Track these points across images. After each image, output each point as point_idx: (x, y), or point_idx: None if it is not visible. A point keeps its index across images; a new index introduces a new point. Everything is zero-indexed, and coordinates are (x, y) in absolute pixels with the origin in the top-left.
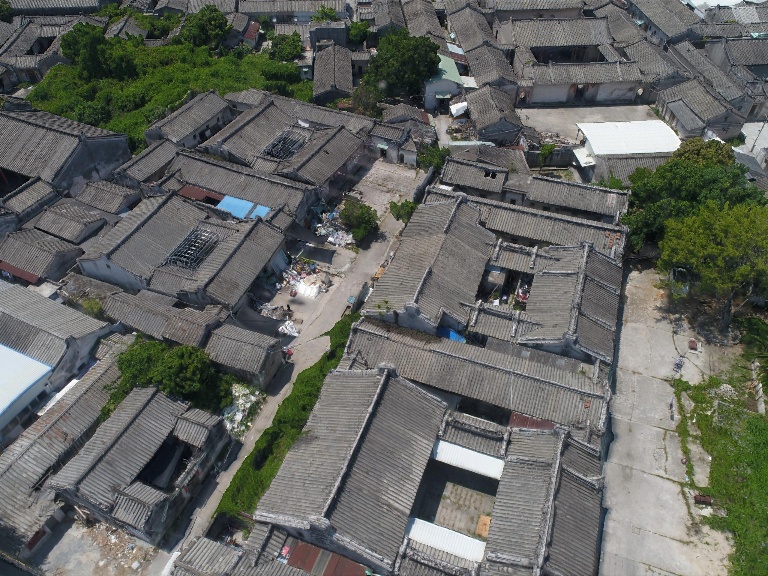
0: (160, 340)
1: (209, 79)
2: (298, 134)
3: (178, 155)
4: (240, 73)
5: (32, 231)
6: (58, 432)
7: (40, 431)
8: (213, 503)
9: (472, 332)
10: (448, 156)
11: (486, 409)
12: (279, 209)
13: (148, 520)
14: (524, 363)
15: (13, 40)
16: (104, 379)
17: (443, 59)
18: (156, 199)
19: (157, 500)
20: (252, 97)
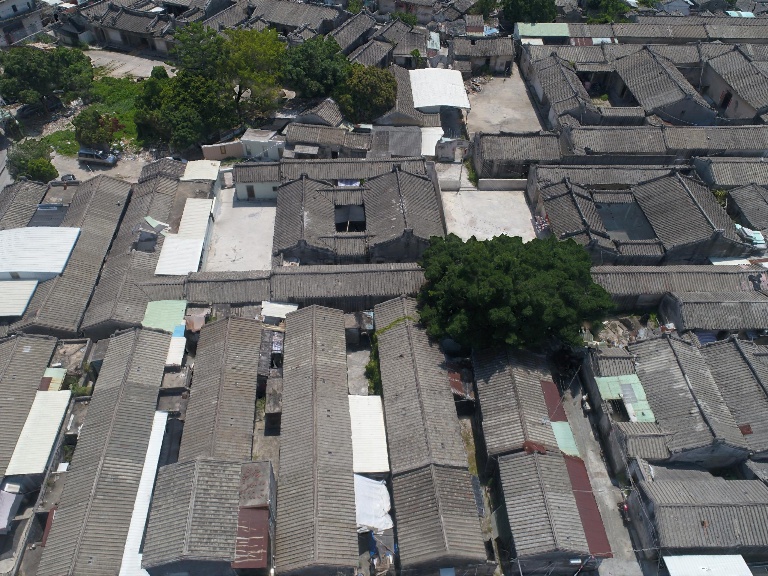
0: None
1: None
2: None
3: None
4: None
5: None
6: None
7: None
8: None
9: None
10: None
11: None
12: None
13: None
14: None
15: None
16: None
17: (559, 27)
18: None
19: None
20: None
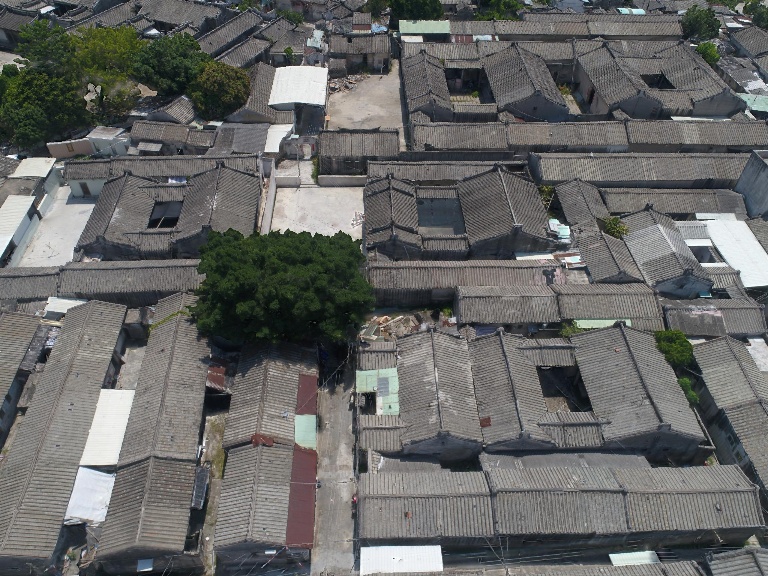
0: None
1: None
2: None
3: None
4: None
5: None
6: None
7: None
8: None
9: None
10: None
11: None
12: None
13: None
14: None
15: None
16: None
17: (441, 24)
18: None
19: None
20: None
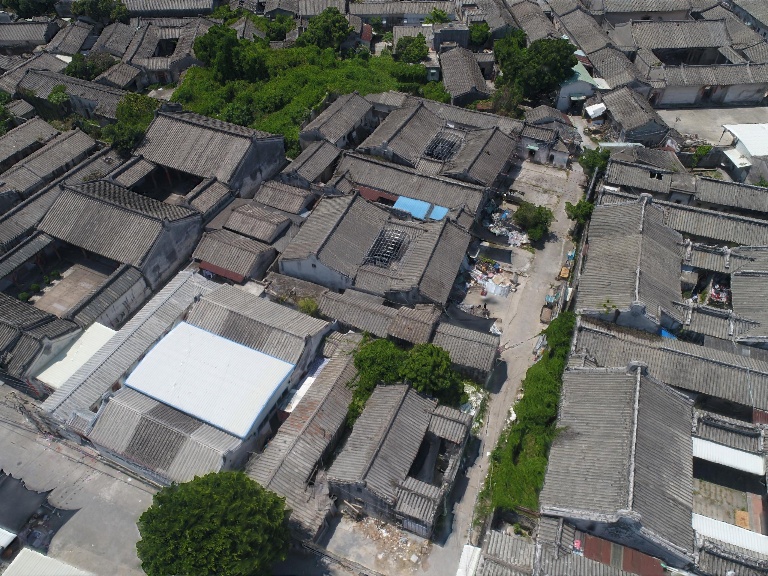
0: (383, 338)
1: (347, 81)
2: (454, 135)
3: (345, 156)
4: (372, 75)
5: (223, 231)
6: (317, 428)
7: (301, 427)
8: (470, 498)
9: (687, 331)
10: (610, 157)
11: (716, 406)
12: (461, 209)
13: (435, 514)
14: (751, 361)
15: (140, 42)
16: (345, 376)
17: None
18: (338, 200)
19: (437, 494)
20: (393, 99)
